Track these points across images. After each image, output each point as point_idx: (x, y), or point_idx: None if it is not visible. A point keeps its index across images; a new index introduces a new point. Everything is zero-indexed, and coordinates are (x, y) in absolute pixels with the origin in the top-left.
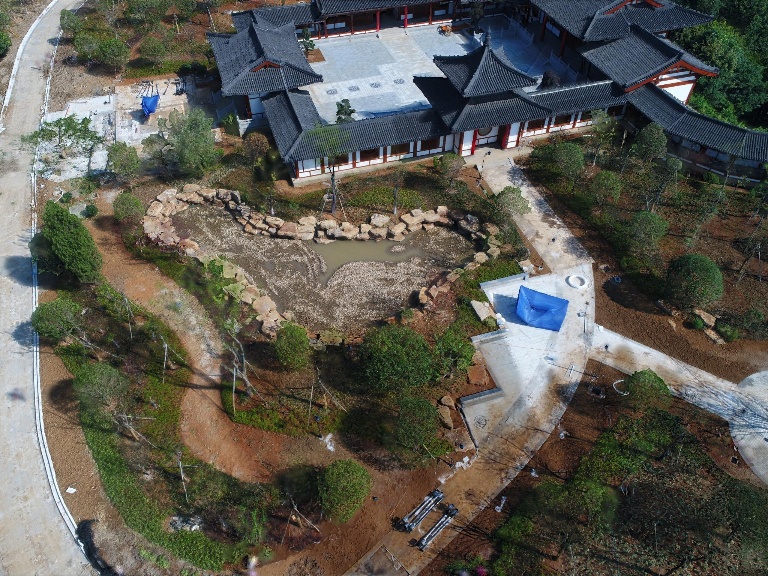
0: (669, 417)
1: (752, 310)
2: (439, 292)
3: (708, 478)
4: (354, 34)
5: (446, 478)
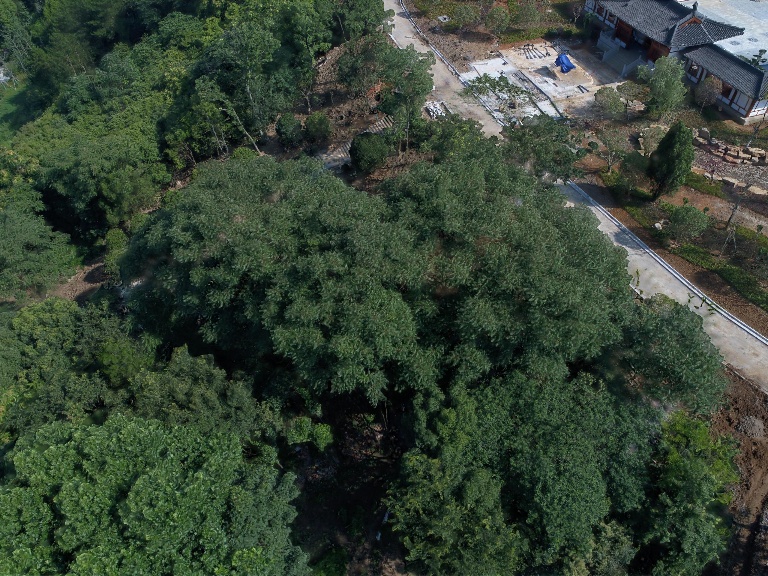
0: None
1: None
2: None
3: None
4: None
5: None
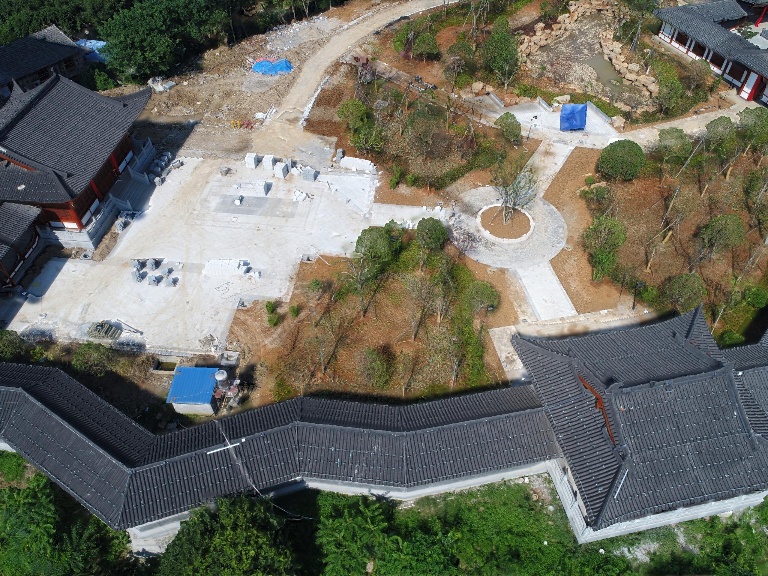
0: None
1: None
2: (575, 89)
3: (460, 162)
4: None
5: (445, 91)
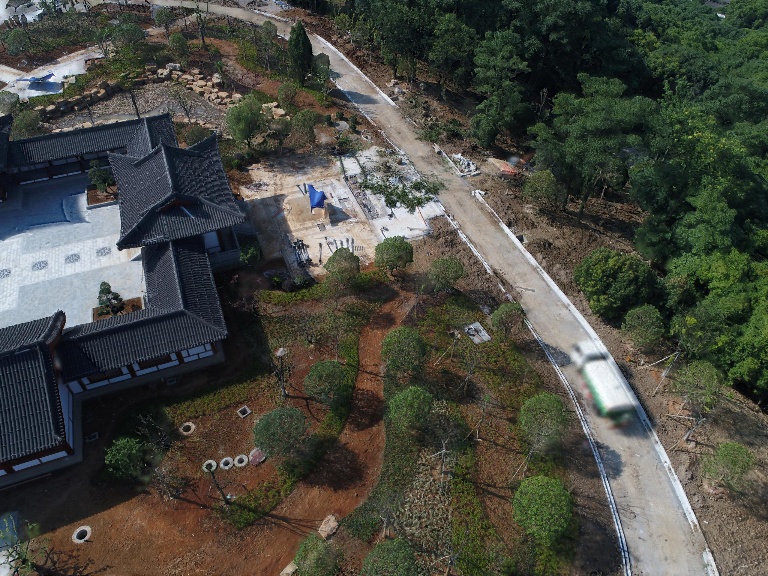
0: (12, 53)
1: None
2: None
3: None
4: None
5: None
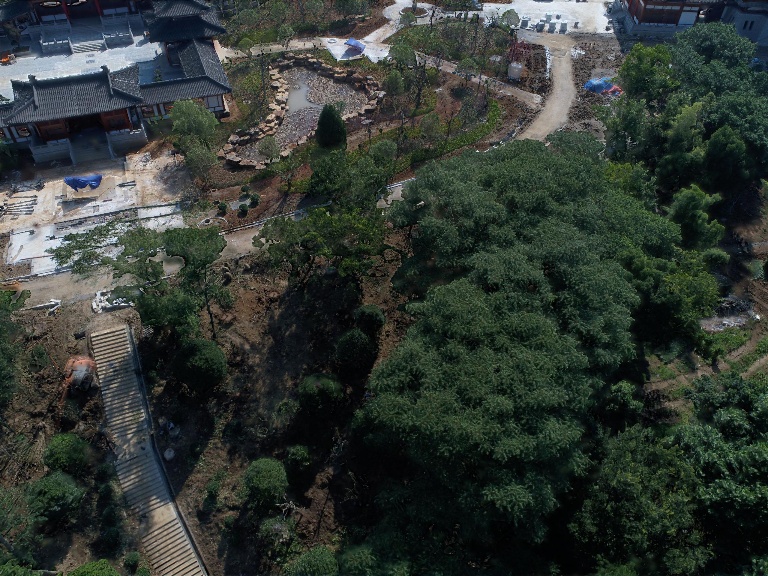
0: (411, 30)
1: (364, 1)
2: None
3: None
4: None
5: None
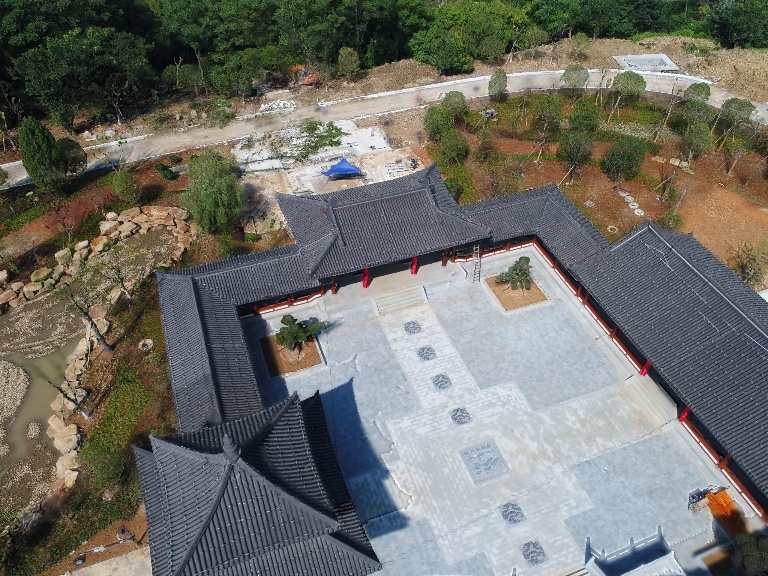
0: None
1: None
2: None
3: None
4: (613, 339)
5: None
